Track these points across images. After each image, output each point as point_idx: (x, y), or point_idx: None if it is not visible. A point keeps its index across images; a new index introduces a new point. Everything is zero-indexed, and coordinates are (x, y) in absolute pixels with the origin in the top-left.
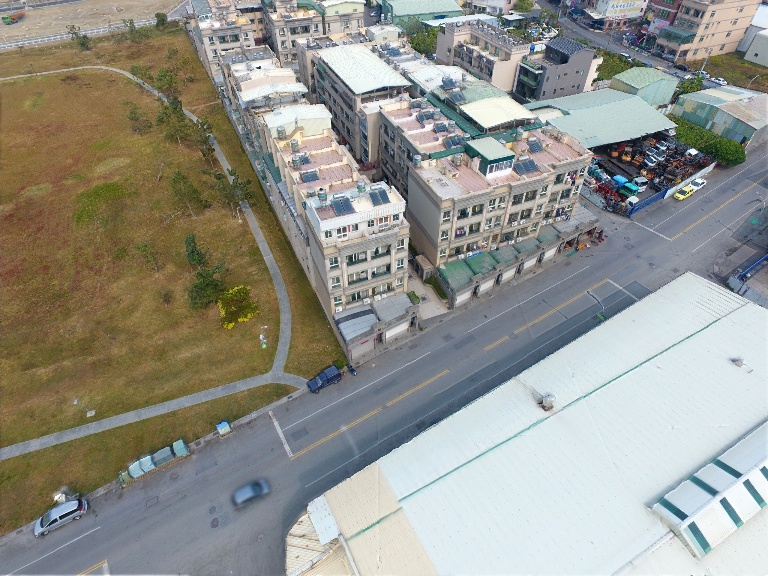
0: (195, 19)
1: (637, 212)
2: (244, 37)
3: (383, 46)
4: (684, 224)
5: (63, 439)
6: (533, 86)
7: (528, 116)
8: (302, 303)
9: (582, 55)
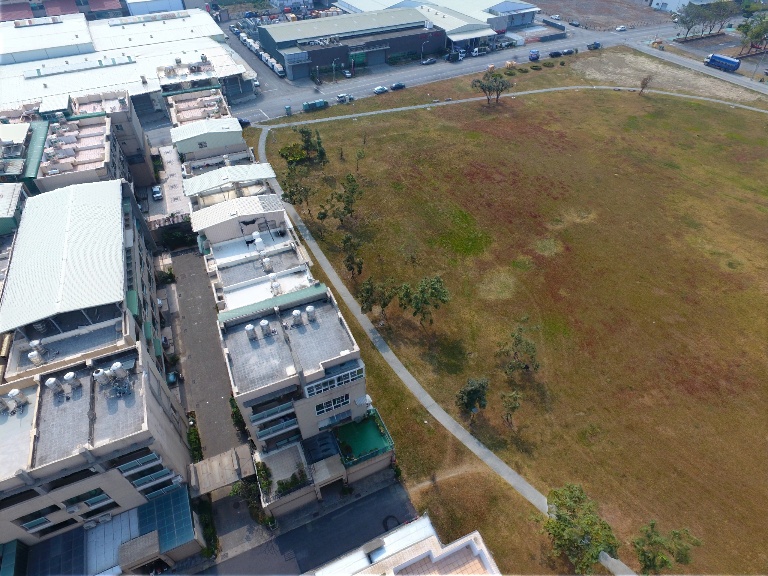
0: None
1: None
2: None
3: None
4: None
5: (362, 114)
6: None
7: None
8: None
9: None
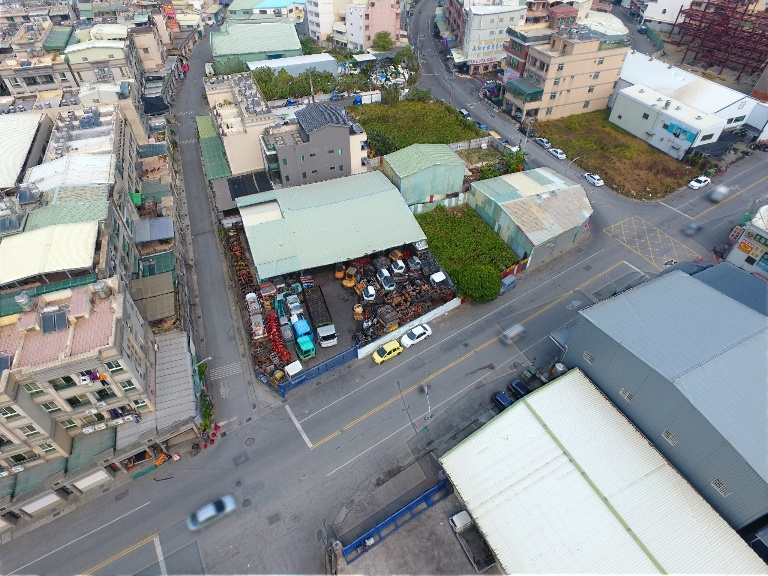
0: None
1: (302, 385)
2: None
3: (87, 111)
4: (353, 413)
5: None
6: (271, 169)
7: (72, 265)
8: None
9: (329, 131)
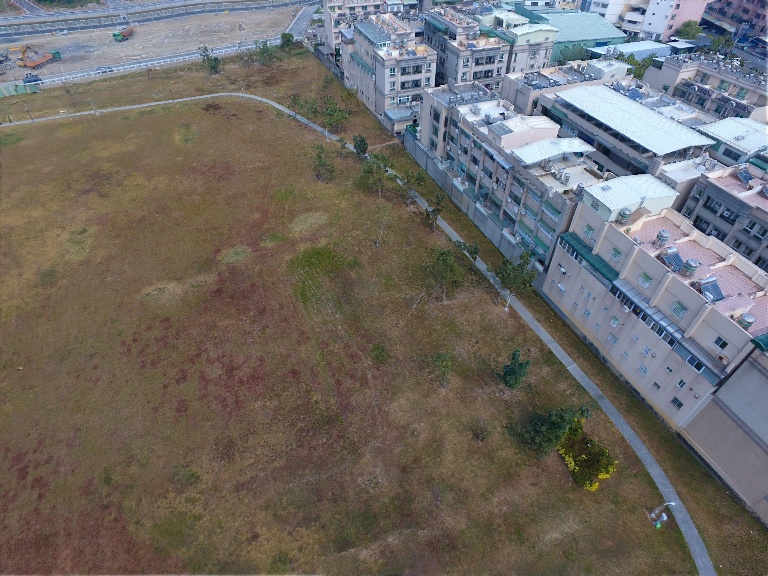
0: (354, 44)
1: None
2: (426, 68)
3: (615, 85)
4: None
5: None
6: None
7: None
8: (663, 448)
9: None
